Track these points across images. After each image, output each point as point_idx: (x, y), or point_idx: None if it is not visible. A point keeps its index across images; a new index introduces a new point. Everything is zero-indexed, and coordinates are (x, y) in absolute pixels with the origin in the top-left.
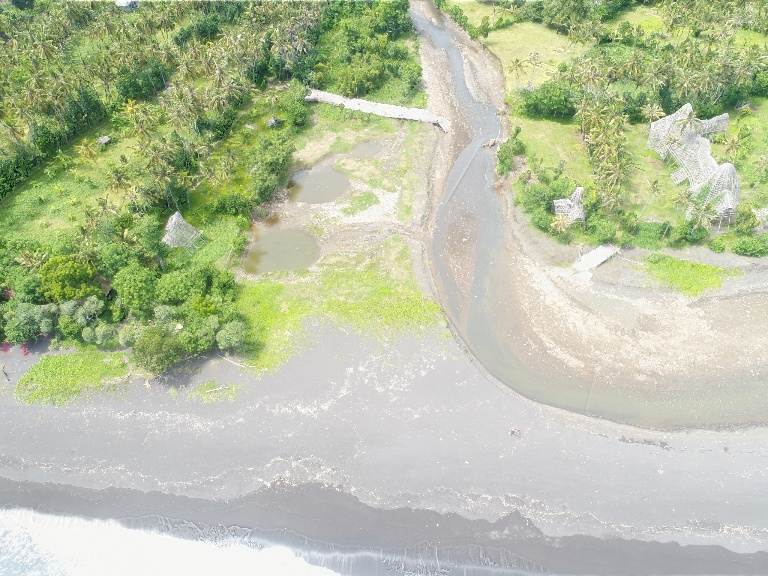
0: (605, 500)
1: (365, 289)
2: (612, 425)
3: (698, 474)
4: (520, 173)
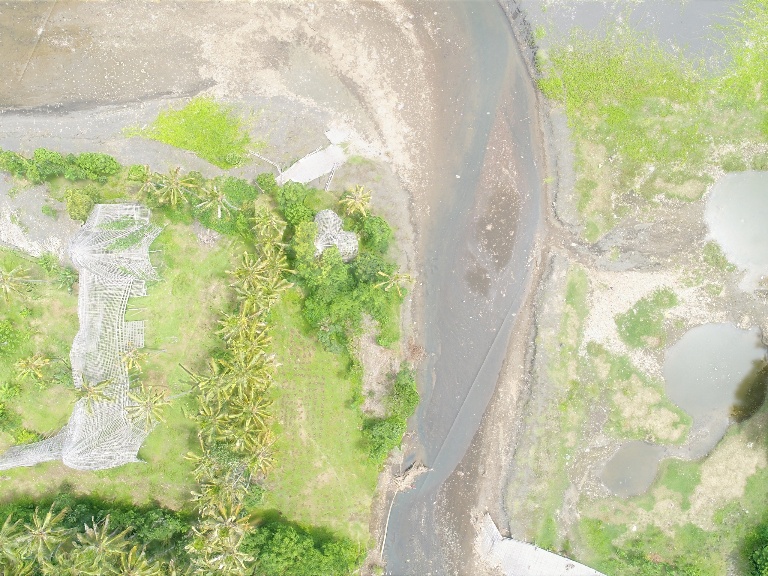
0: None
1: (645, 120)
2: None
3: None
4: (383, 368)
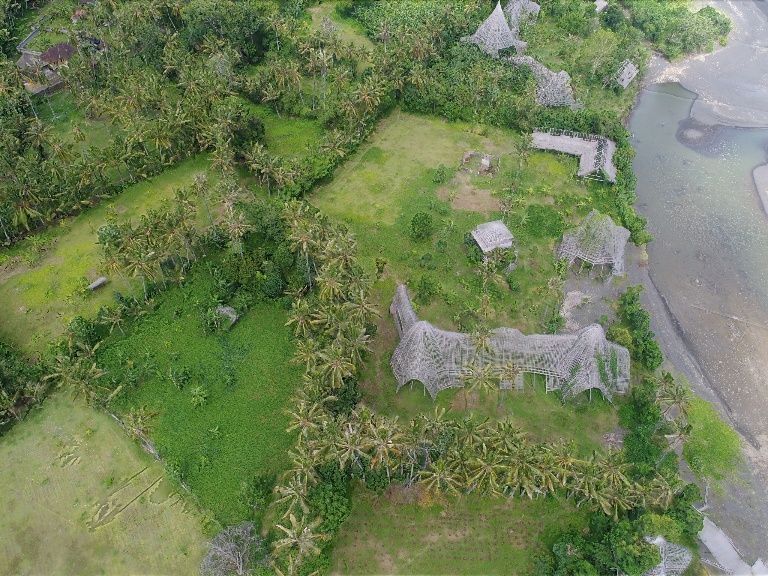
0: None
1: None
2: None
3: None
4: None
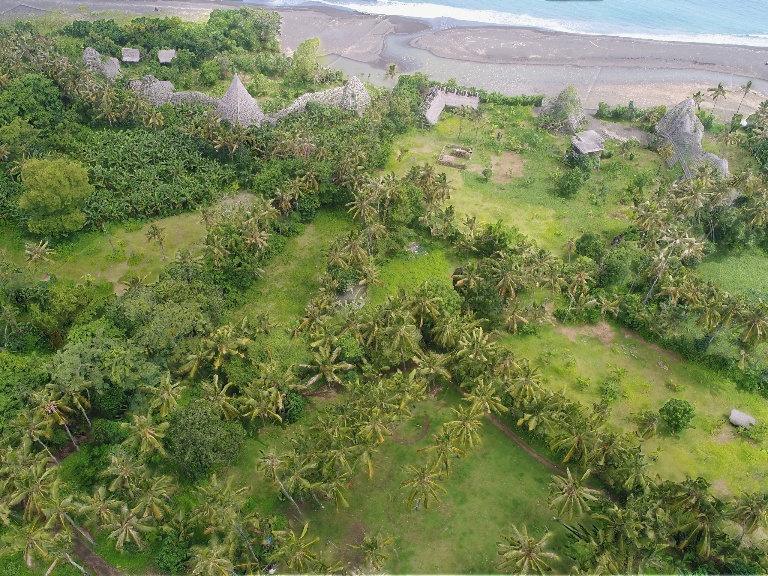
0: (721, 49)
1: None
2: (719, 70)
3: (682, 52)
4: None
